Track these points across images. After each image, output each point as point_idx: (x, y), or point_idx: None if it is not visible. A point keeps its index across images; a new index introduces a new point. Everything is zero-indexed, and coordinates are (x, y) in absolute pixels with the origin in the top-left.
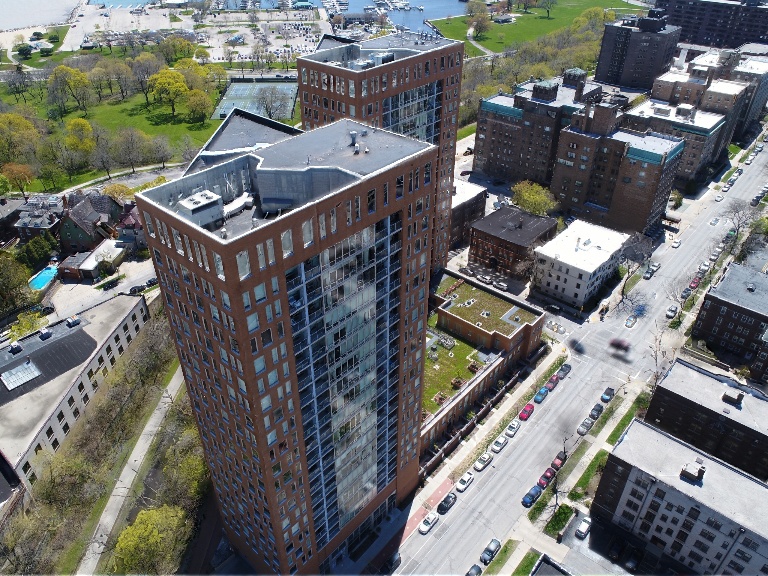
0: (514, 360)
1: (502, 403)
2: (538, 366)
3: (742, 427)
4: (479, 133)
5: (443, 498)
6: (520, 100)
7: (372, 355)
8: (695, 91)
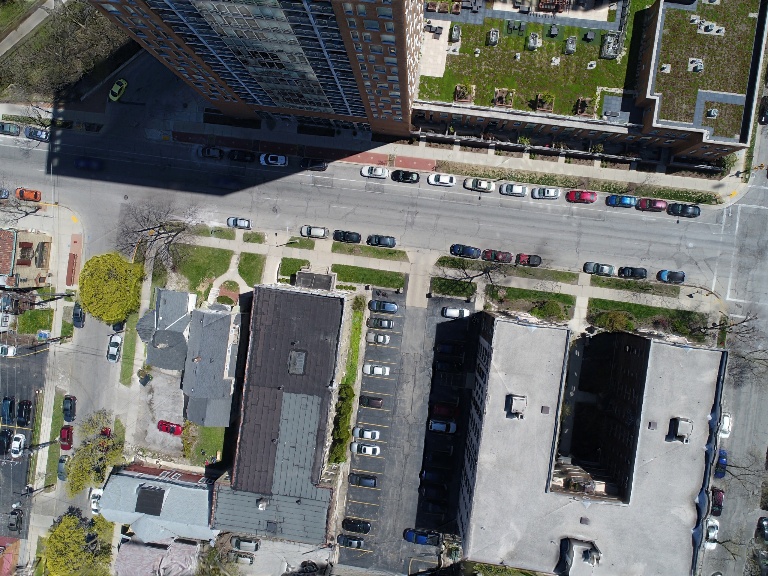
0: (654, 143)
1: (579, 163)
2: (676, 175)
3: (635, 446)
4: None
5: (410, 169)
6: None
7: (282, 21)
8: None
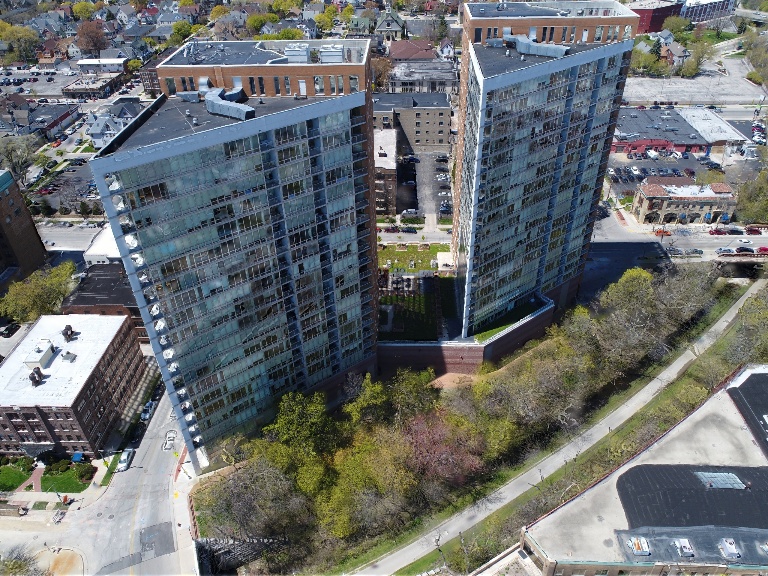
0: None
1: None
2: None
3: None
4: None
5: None
6: None
7: None
8: None
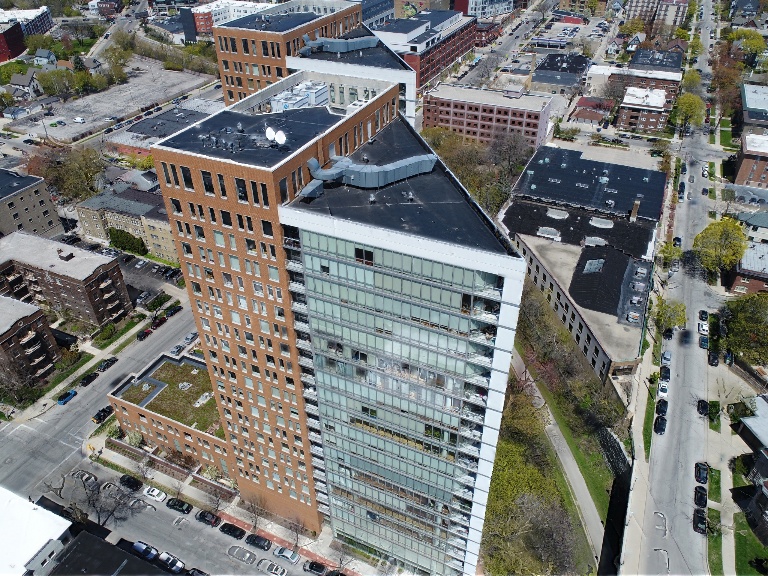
0: None
1: None
2: None
3: None
4: None
5: None
6: None
7: None
8: None
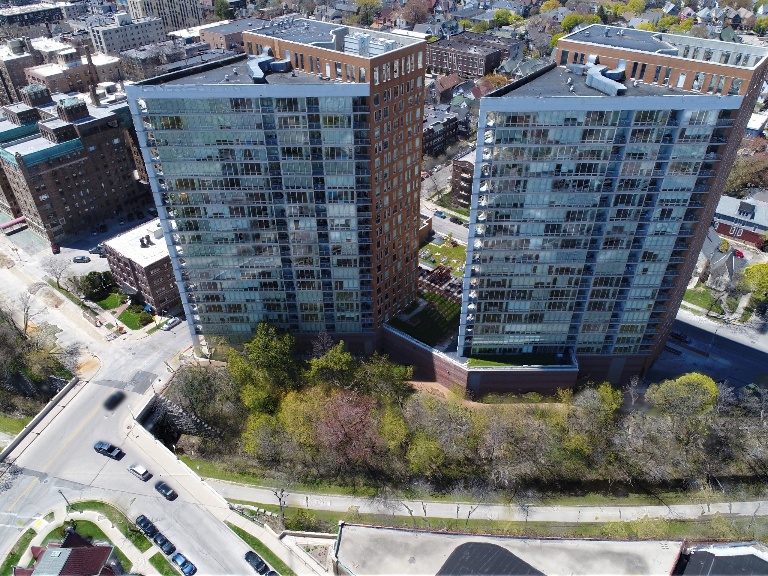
0: None
1: None
2: None
3: None
4: (38, 196)
5: None
6: (63, 131)
7: None
8: (82, 73)
